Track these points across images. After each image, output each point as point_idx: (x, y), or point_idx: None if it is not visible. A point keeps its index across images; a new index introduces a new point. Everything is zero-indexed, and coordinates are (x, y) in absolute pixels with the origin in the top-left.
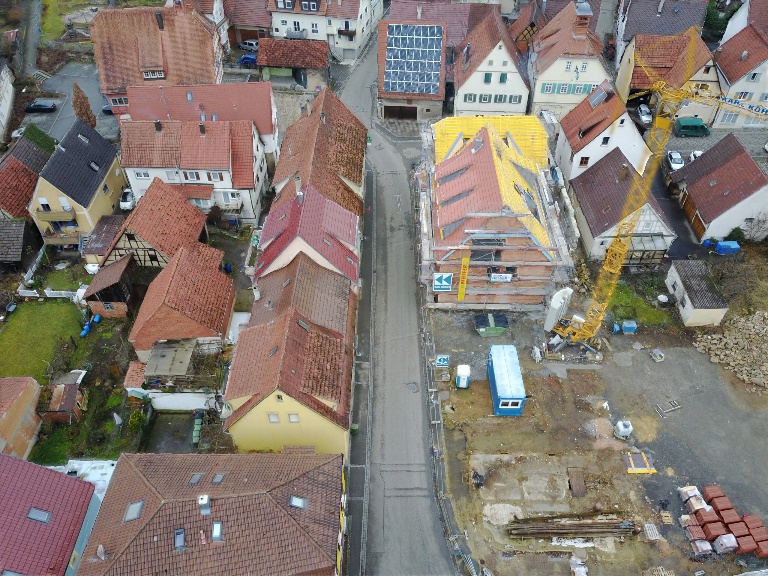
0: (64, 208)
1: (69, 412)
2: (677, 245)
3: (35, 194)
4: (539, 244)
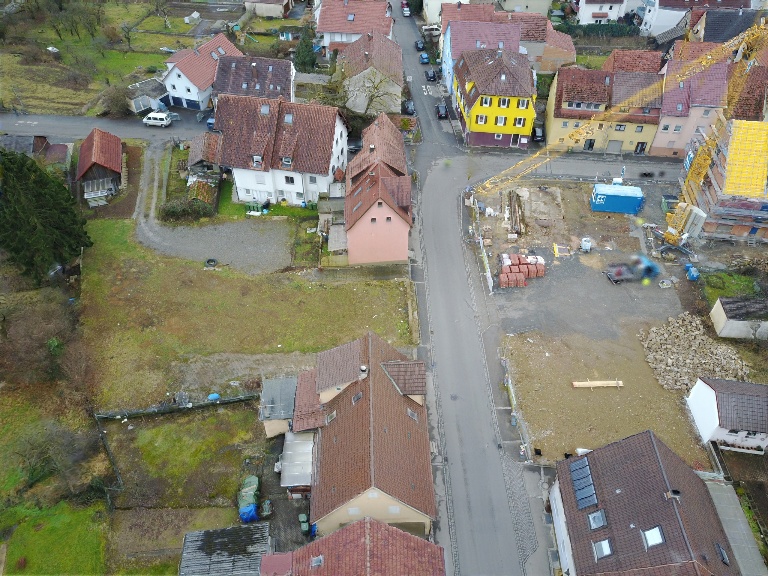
0: (700, 37)
1: None
2: None
3: (700, 21)
4: (725, 168)
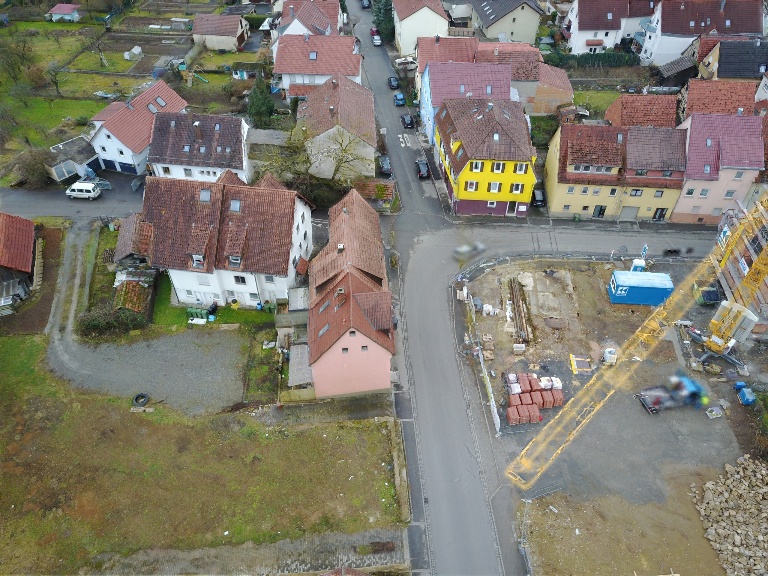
0: (712, 71)
1: (561, 116)
2: None
3: (711, 52)
4: None
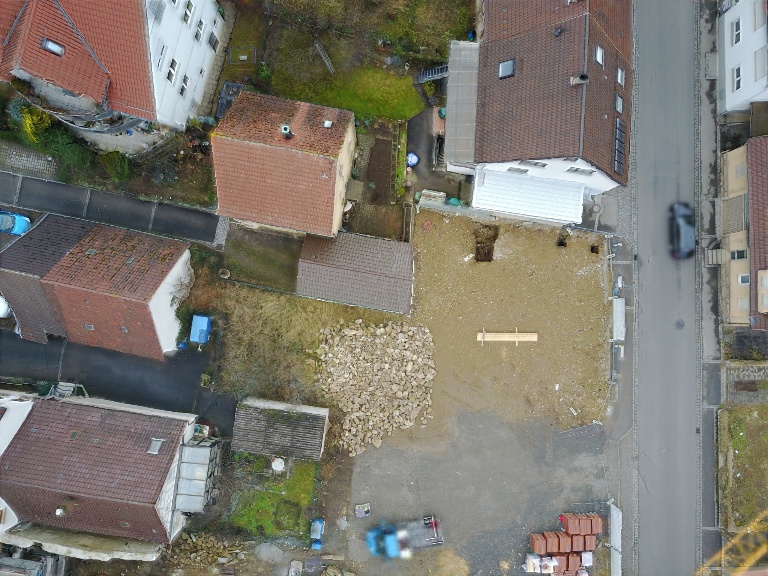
0: None
1: None
2: (173, 383)
3: None
4: None
